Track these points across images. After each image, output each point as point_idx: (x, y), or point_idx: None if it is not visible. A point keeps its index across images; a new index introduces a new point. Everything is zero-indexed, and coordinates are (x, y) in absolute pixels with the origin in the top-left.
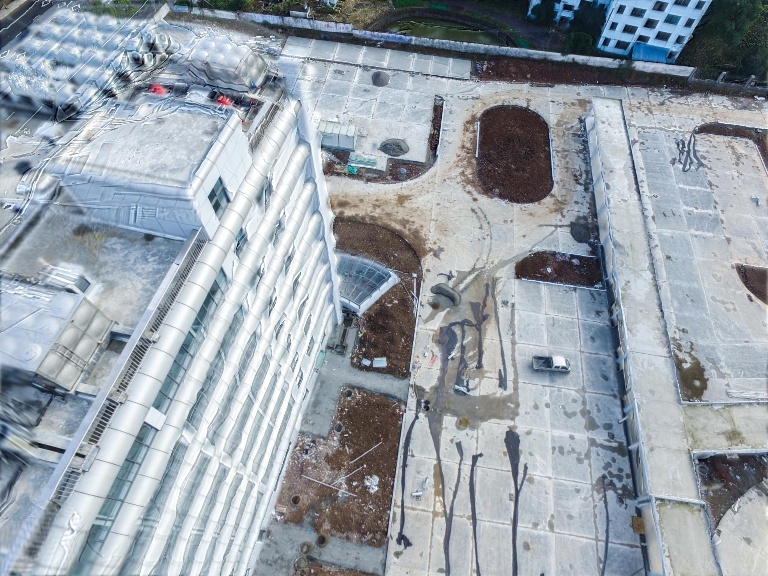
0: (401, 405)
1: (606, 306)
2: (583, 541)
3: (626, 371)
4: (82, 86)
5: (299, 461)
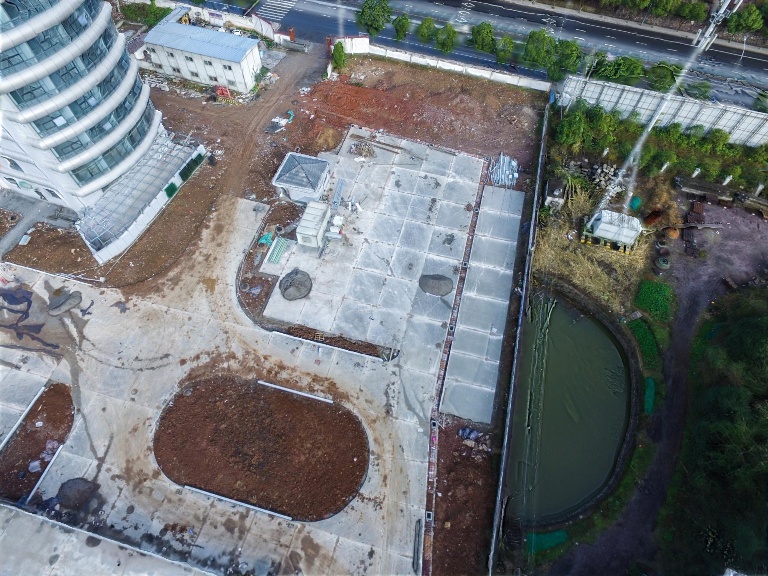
0: None
1: None
2: None
3: None
4: (417, 54)
5: None
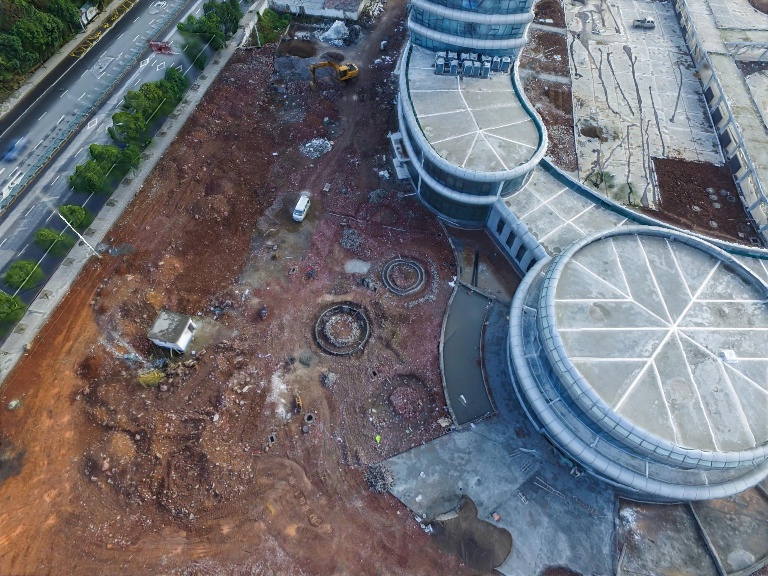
0: None
1: (672, 8)
2: (669, 79)
3: (687, 22)
4: None
5: None
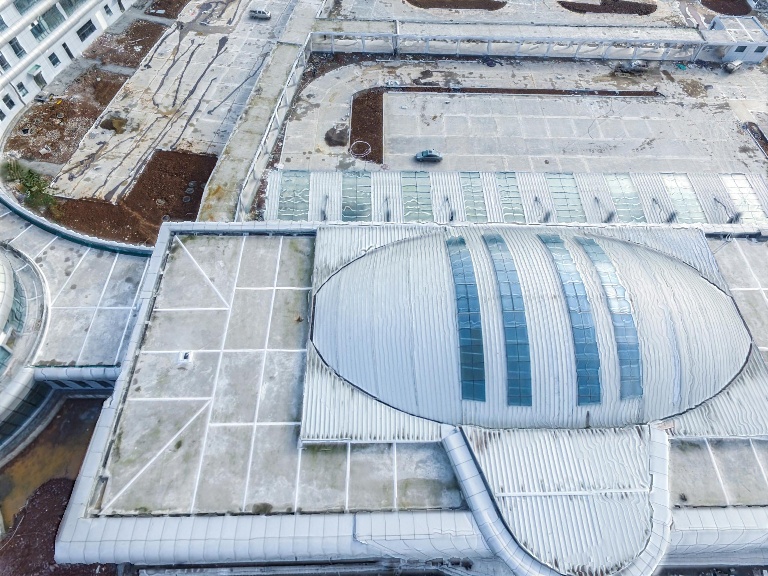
0: (167, 27)
1: None
2: (244, 70)
3: None
4: None
5: (101, 39)
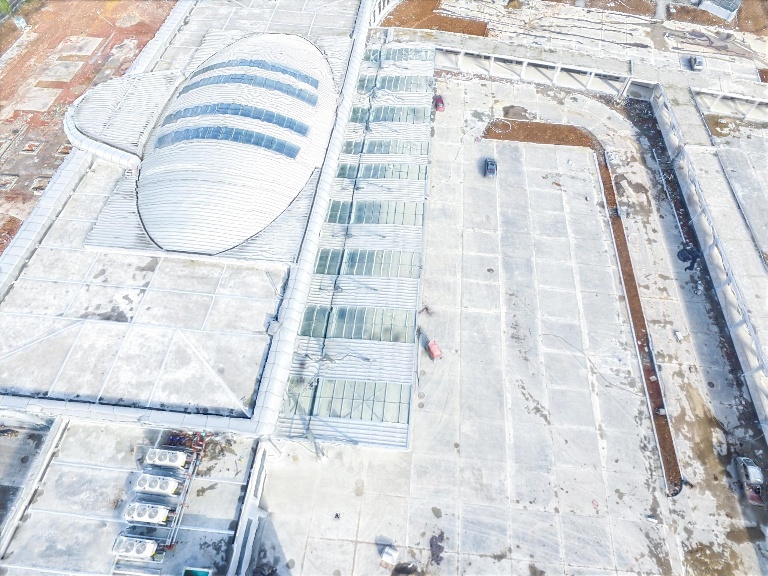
0: (651, 17)
1: None
2: None
3: None
4: None
5: None
